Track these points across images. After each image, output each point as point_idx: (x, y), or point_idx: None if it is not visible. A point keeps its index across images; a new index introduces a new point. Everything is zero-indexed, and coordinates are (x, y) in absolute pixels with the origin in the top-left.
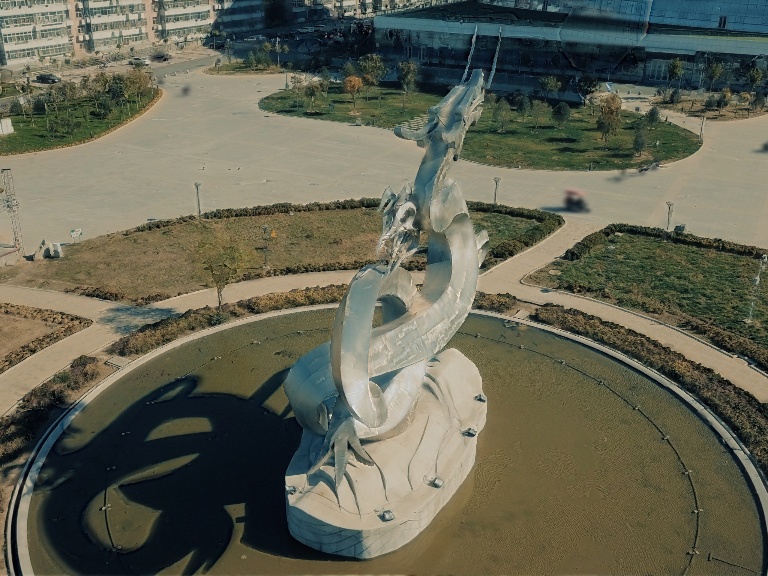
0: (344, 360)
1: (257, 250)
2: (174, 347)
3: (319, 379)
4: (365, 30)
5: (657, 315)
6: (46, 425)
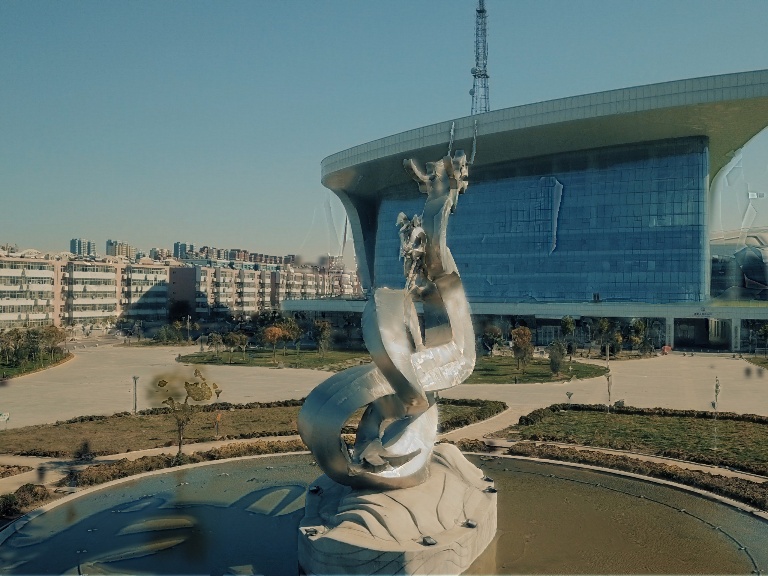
0: (384, 335)
1: (204, 429)
2: (133, 479)
3: (341, 399)
4: (271, 316)
5: (627, 450)
6: None
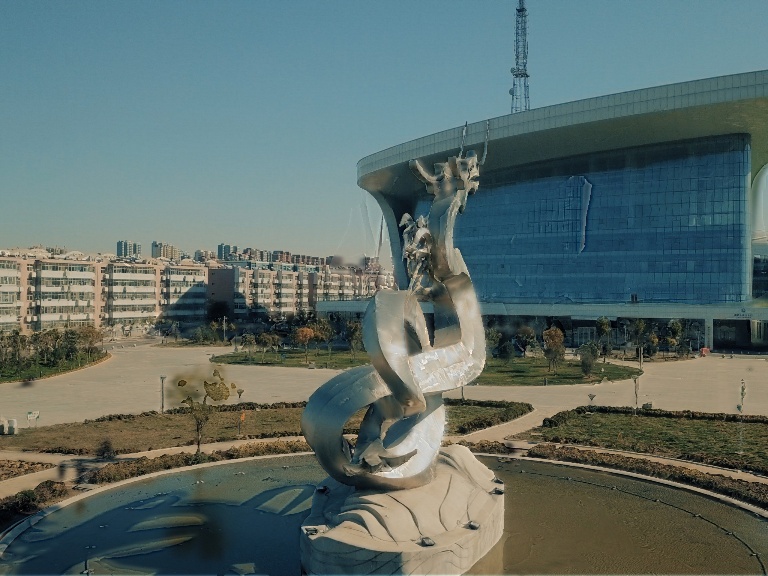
0: (381, 336)
1: (227, 428)
2: (150, 477)
3: (343, 399)
4: (306, 317)
5: None
6: (9, 523)
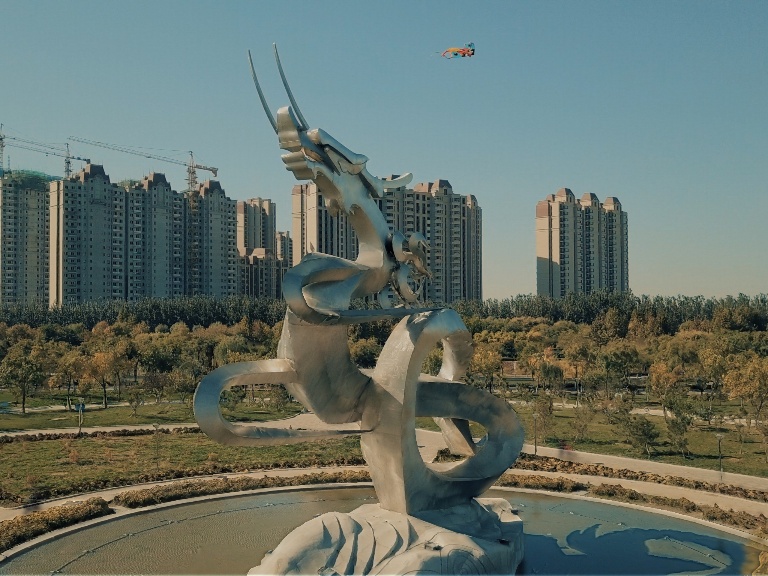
0: None
1: None
2: None
3: None
4: None
5: None
6: None
